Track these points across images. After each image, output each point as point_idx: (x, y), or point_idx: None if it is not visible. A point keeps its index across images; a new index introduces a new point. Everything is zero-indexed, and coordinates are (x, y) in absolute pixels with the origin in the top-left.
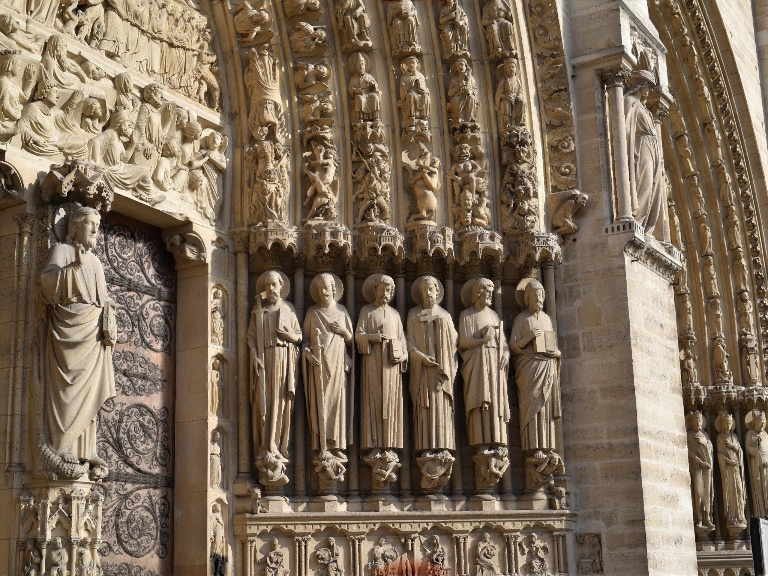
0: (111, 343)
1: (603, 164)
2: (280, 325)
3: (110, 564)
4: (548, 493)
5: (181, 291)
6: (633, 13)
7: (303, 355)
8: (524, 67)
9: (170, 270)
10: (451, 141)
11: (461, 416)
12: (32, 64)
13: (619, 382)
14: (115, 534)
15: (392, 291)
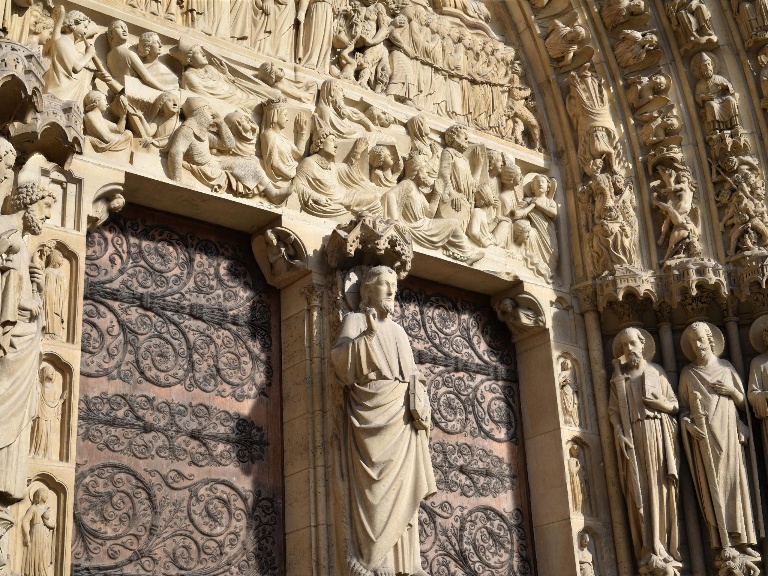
0: (423, 425)
1: None
2: (647, 392)
3: None
4: None
5: (522, 367)
6: None
7: (682, 427)
8: None
9: (506, 344)
10: None
11: None
12: (302, 113)
13: None
14: None
15: None
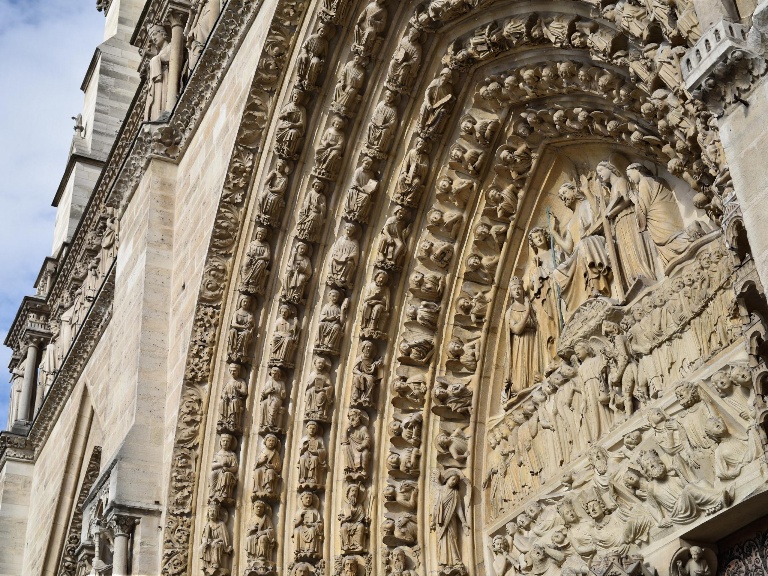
0: None
1: None
2: None
3: None
4: None
5: None
6: None
7: None
8: None
9: None
10: None
11: None
12: None
13: None
14: None
15: None
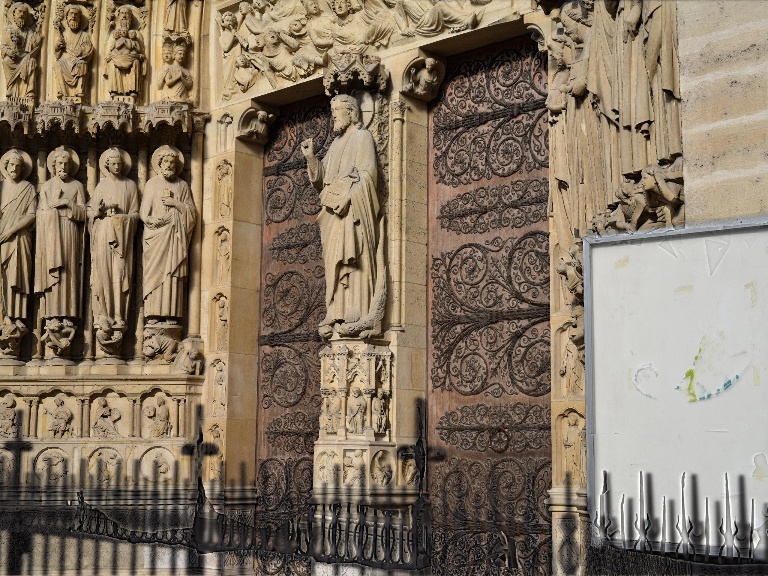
0: None
1: None
2: (548, 98)
3: (504, 405)
4: None
5: None
6: None
7: None
8: None
9: None
10: None
11: None
12: None
13: None
14: None
15: None
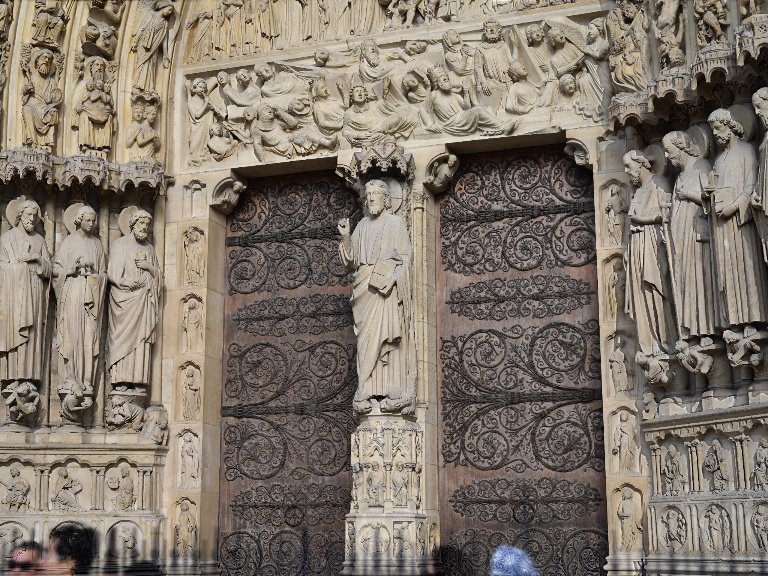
0: (383, 293)
1: None
2: (631, 210)
3: (528, 480)
4: None
5: None
6: None
7: None
8: None
9: (592, 179)
10: None
11: None
12: (339, 79)
13: None
14: (532, 451)
15: (730, 125)
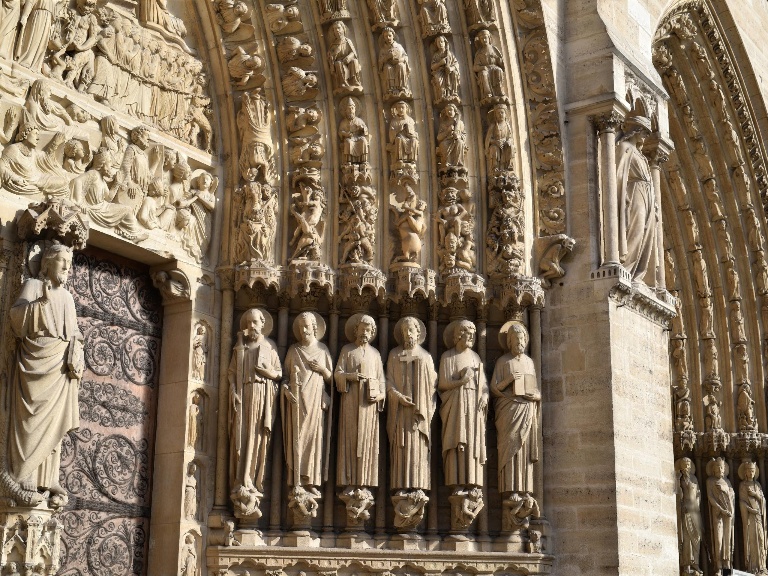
0: (76, 376)
1: (592, 209)
2: (259, 362)
3: None
4: (524, 536)
5: (166, 326)
6: (629, 60)
7: (281, 392)
8: (515, 112)
9: (157, 306)
10: (439, 184)
11: (440, 456)
12: (14, 107)
13: (599, 427)
14: (86, 561)
15: (373, 331)
